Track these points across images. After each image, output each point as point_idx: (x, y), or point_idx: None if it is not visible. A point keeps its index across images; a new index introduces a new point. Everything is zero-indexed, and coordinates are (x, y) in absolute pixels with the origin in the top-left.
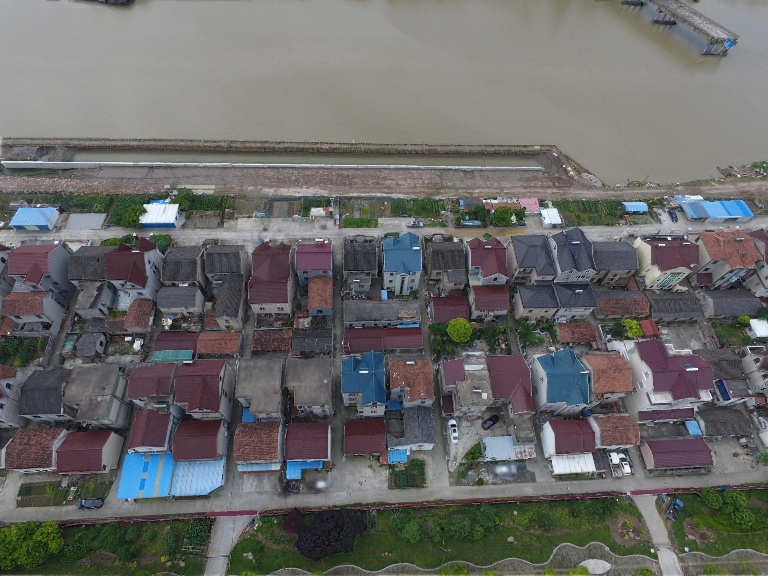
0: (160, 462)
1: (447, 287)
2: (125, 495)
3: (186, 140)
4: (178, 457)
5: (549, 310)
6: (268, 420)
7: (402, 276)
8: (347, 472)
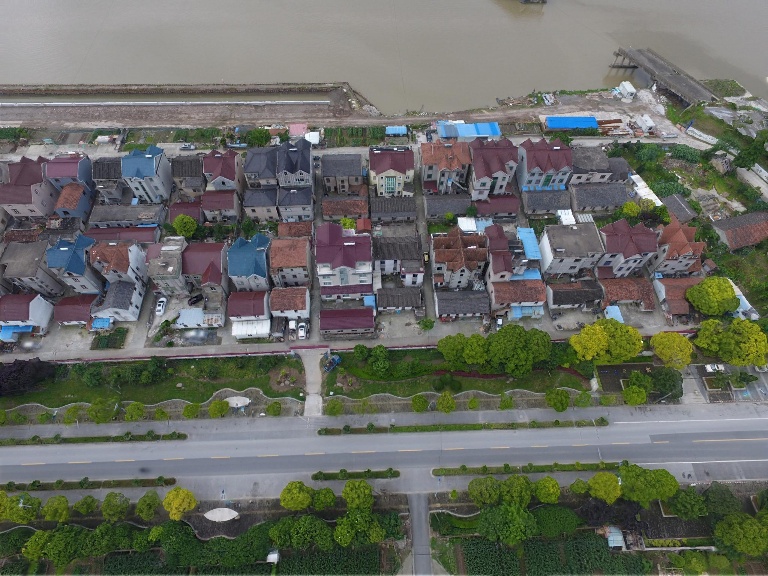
0: None
1: (189, 194)
2: None
3: (9, 85)
4: None
5: (270, 209)
6: None
7: (136, 180)
8: (58, 337)
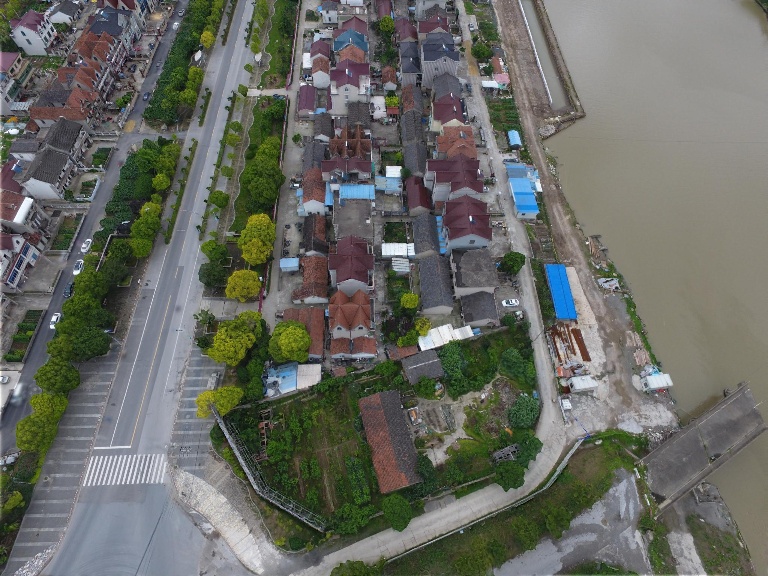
0: None
1: None
2: None
3: None
4: None
5: None
6: None
7: None
8: (316, 1)
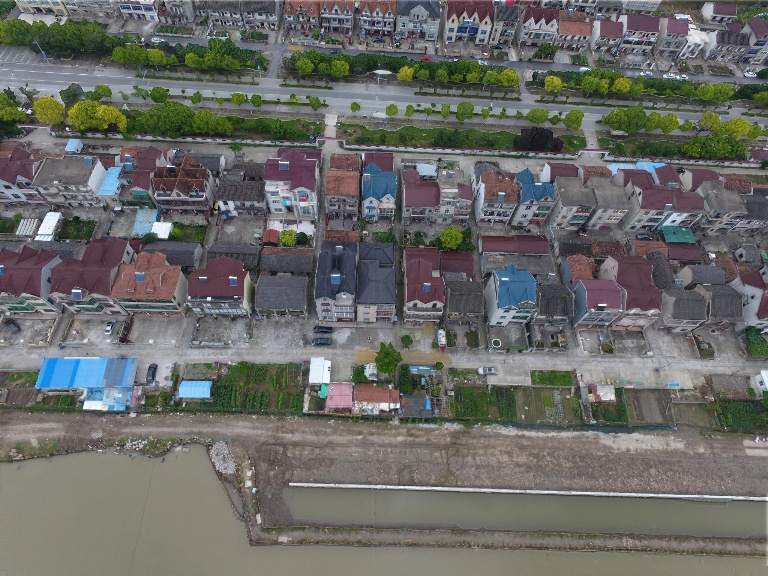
0: None
1: None
2: (662, 164)
3: None
4: None
5: None
6: None
7: None
8: None
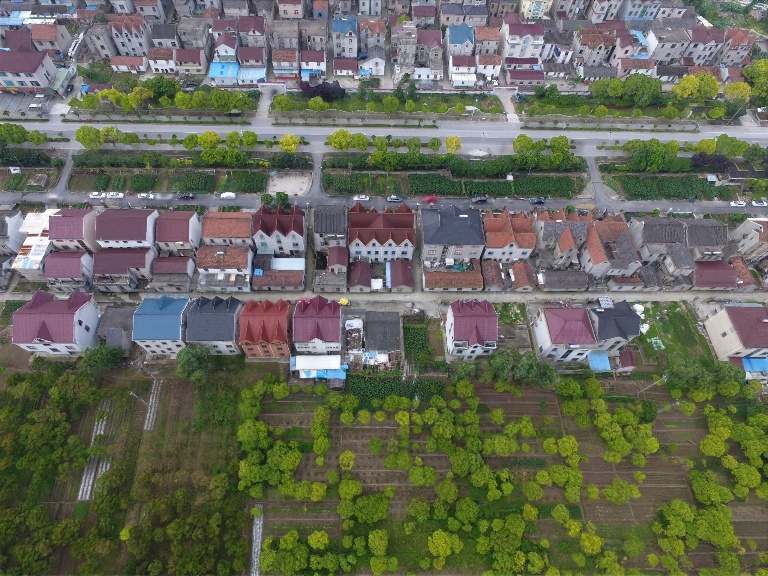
0: (231, 65)
1: (398, 10)
2: (213, 76)
3: None
4: (241, 58)
5: (459, 18)
6: (290, 49)
7: None
8: None
